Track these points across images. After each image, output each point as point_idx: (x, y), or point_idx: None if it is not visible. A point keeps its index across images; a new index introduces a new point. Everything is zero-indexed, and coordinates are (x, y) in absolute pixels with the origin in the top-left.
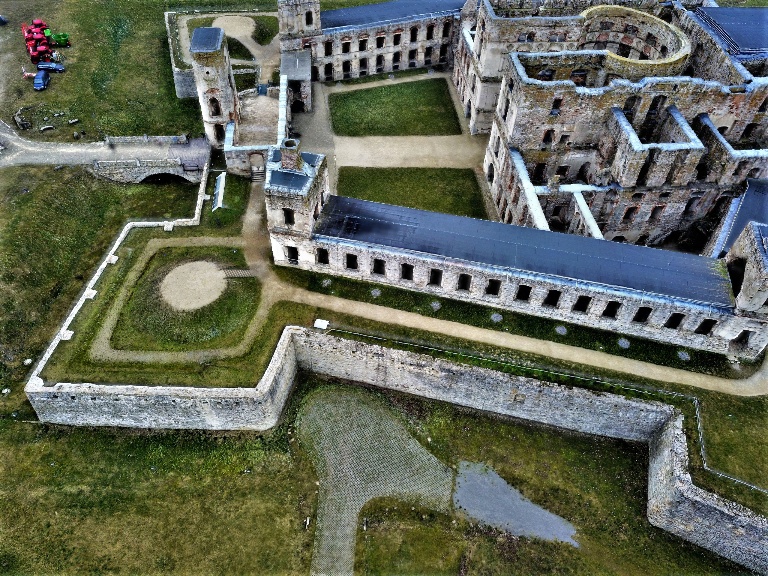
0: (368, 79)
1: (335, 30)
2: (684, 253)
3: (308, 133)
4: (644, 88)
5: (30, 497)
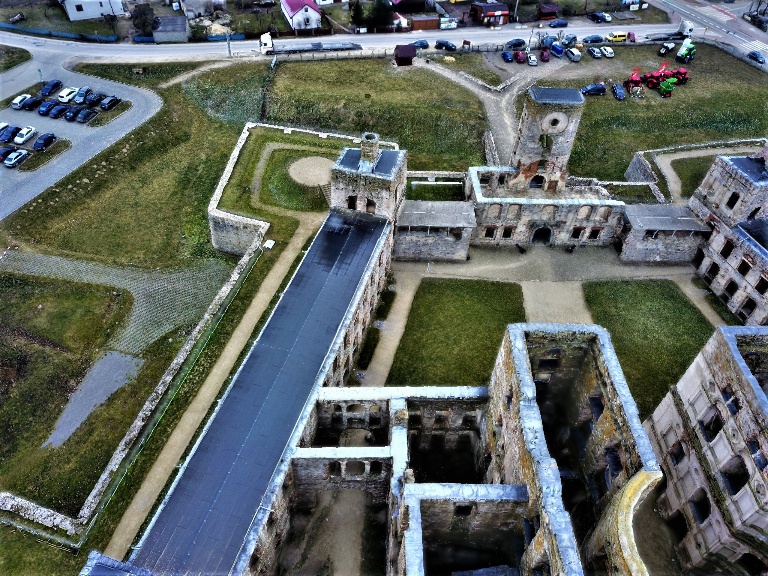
0: (735, 323)
1: (749, 239)
2: (238, 551)
3: (578, 259)
4: (545, 513)
5: (201, 154)
